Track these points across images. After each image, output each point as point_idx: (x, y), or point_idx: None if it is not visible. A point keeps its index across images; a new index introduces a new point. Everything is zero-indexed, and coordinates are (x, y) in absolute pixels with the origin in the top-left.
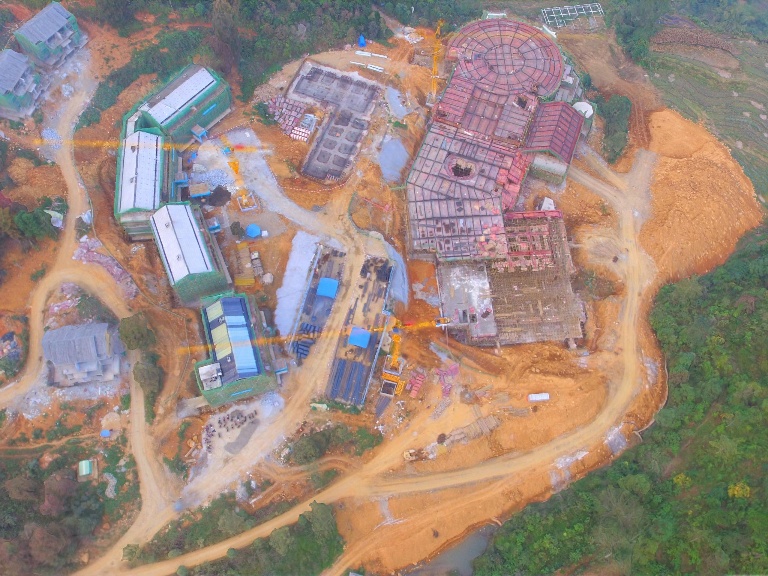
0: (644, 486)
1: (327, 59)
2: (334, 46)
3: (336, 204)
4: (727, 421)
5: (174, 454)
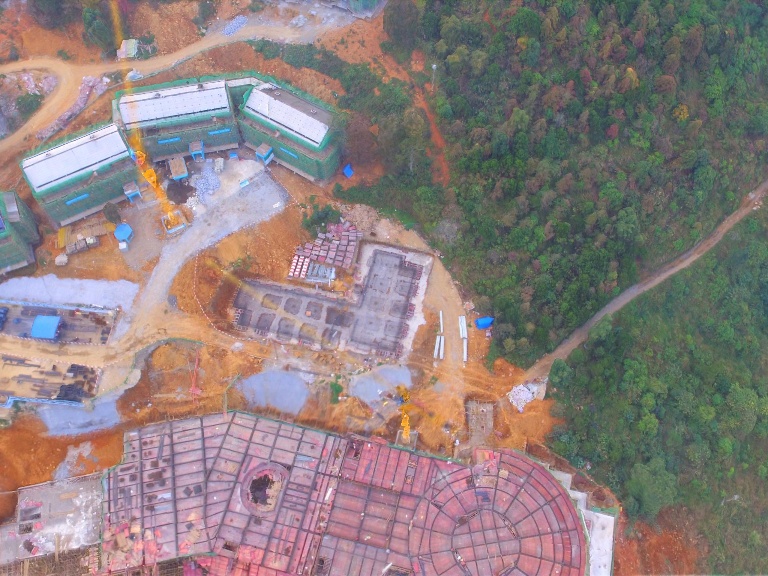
0: None
1: (438, 280)
2: (465, 286)
3: (184, 322)
4: None
5: None
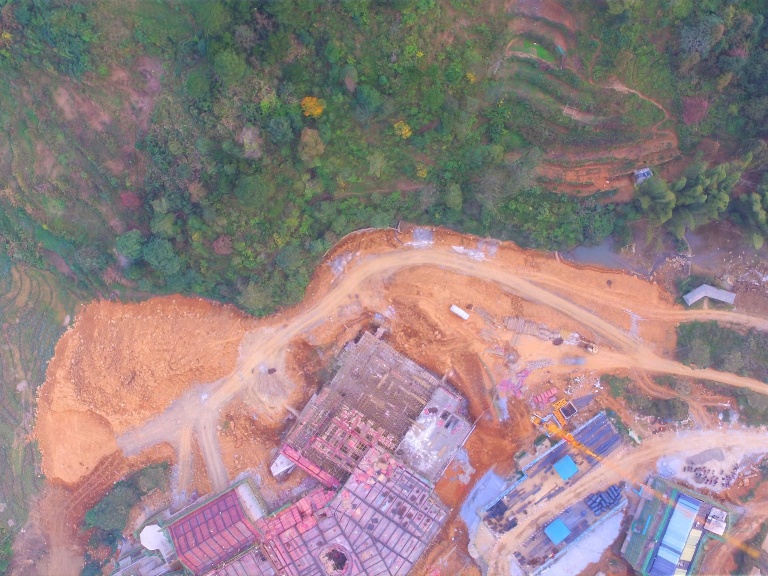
0: (457, 190)
1: None
2: None
3: None
4: (344, 179)
5: (766, 483)
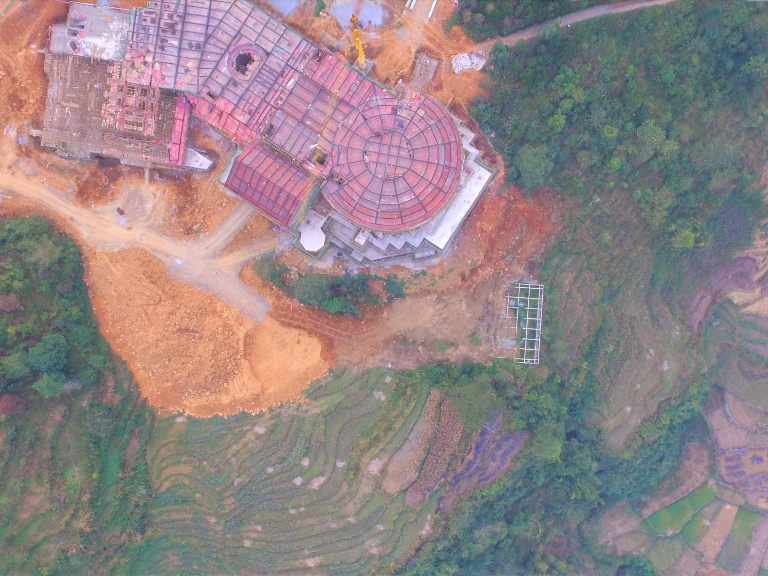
0: None
1: None
2: None
3: None
4: None
5: None
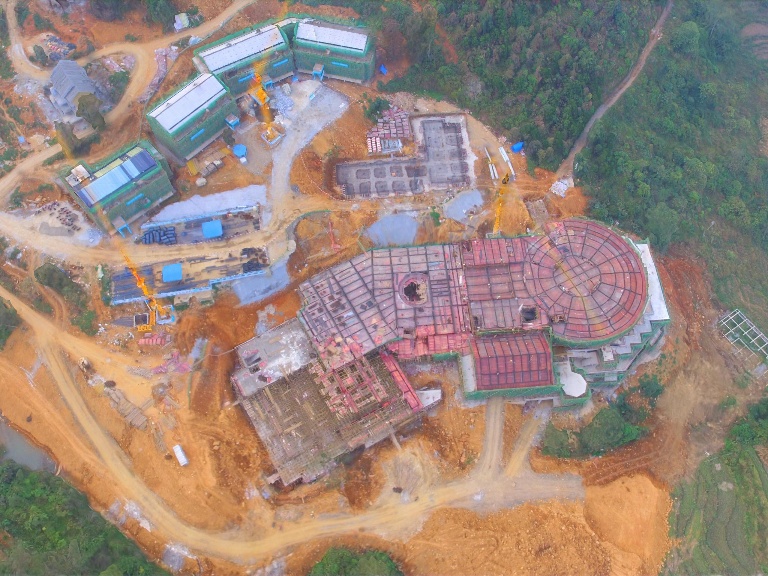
0: None
1: (475, 128)
2: (495, 127)
3: (310, 201)
4: None
5: (25, 191)
